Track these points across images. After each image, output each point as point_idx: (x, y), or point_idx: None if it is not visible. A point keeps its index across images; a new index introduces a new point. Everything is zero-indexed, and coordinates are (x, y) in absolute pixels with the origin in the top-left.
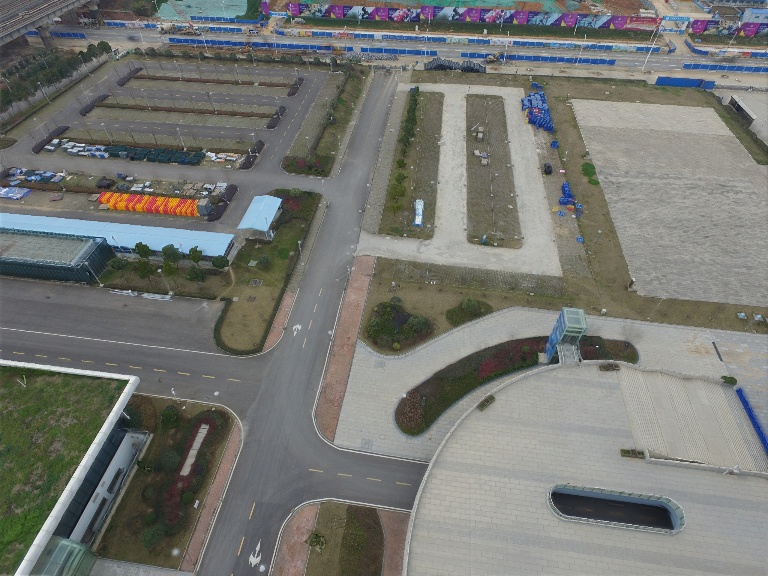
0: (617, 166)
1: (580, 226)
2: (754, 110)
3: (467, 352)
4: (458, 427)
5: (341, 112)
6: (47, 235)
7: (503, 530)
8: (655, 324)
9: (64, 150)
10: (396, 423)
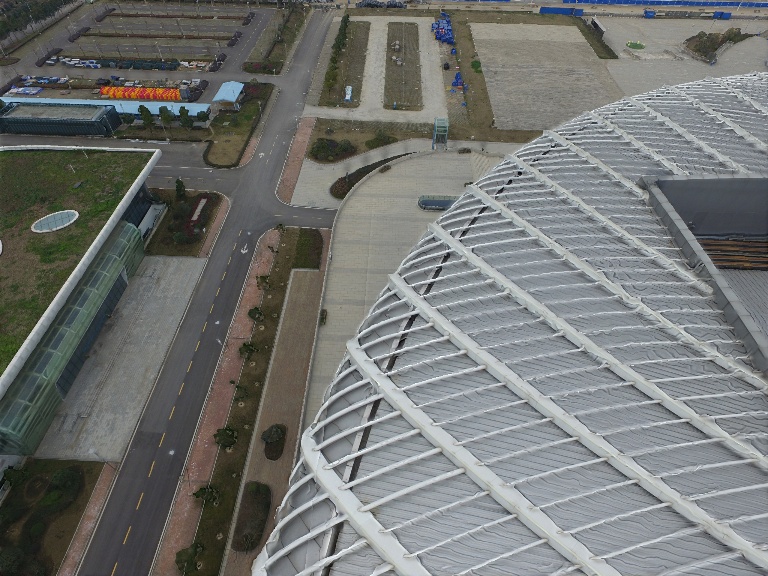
0: (497, 62)
1: (465, 97)
2: (610, 29)
3: (379, 160)
4: (367, 180)
5: (287, 35)
6: (69, 105)
7: (390, 216)
8: (506, 143)
9: (62, 64)
10: (331, 194)
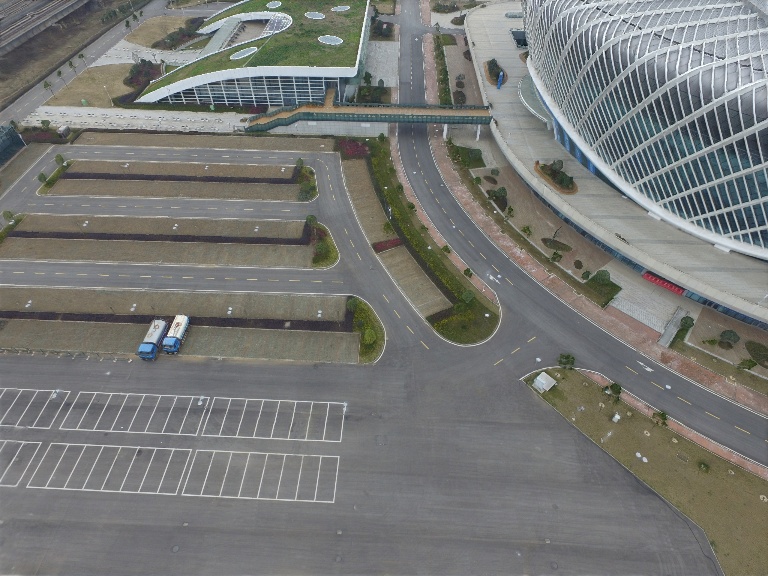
0: None
1: None
2: None
3: None
4: (475, 10)
5: None
6: None
7: (492, 20)
8: None
9: None
10: (452, 23)
